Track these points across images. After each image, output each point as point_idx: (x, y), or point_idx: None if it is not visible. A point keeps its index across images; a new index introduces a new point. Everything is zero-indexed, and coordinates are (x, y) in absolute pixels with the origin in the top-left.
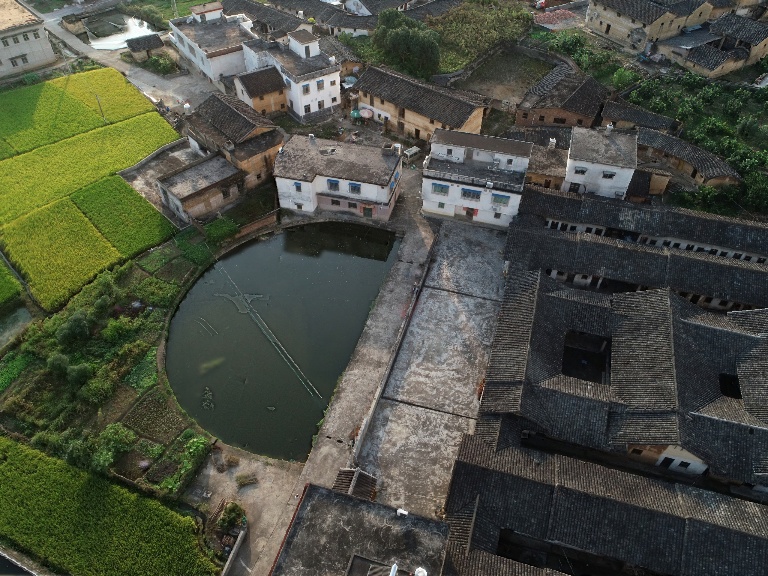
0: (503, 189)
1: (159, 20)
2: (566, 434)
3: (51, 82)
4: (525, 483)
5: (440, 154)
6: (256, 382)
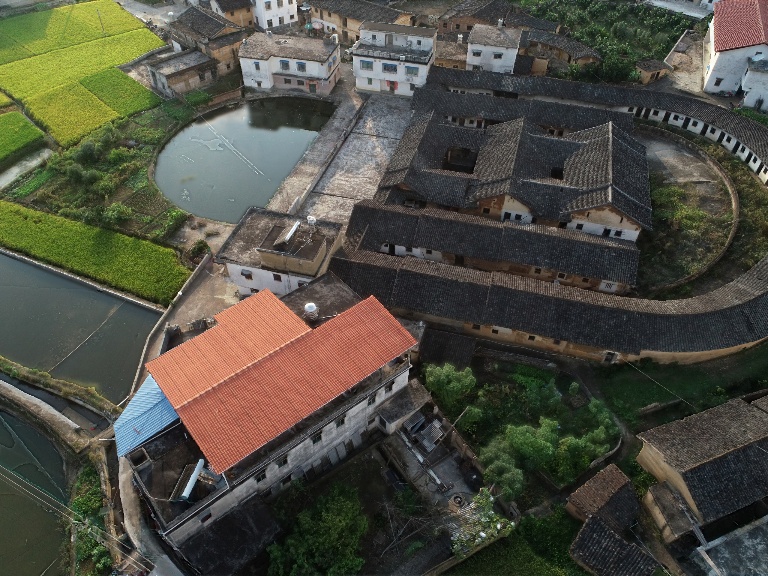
0: (413, 61)
1: None
2: (437, 199)
3: (59, 9)
4: (400, 216)
5: (367, 40)
6: (221, 188)
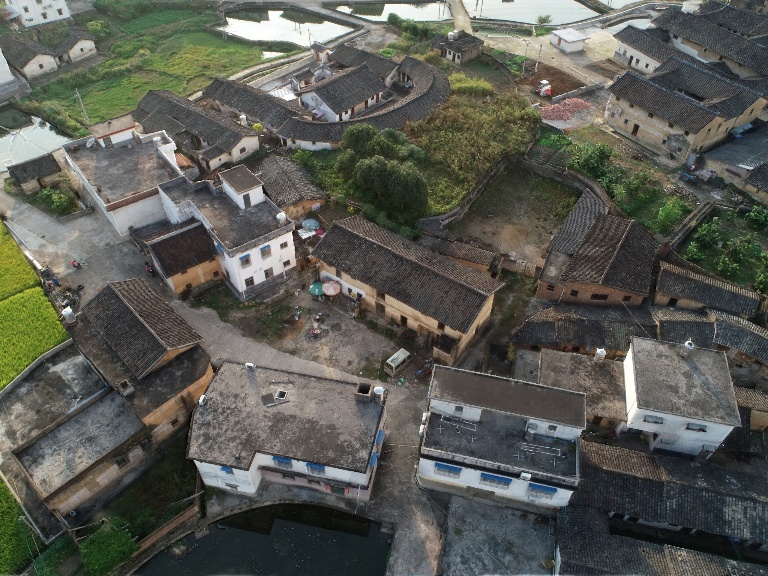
0: (546, 481)
1: (62, 123)
2: None
3: None
4: None
5: (444, 410)
6: None
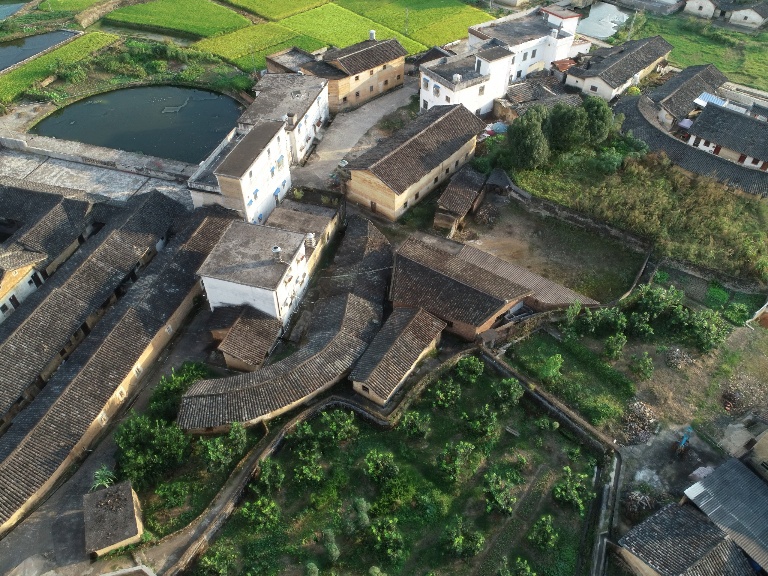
0: None
1: None
2: None
3: (468, 7)
4: None
5: None
6: (100, 118)
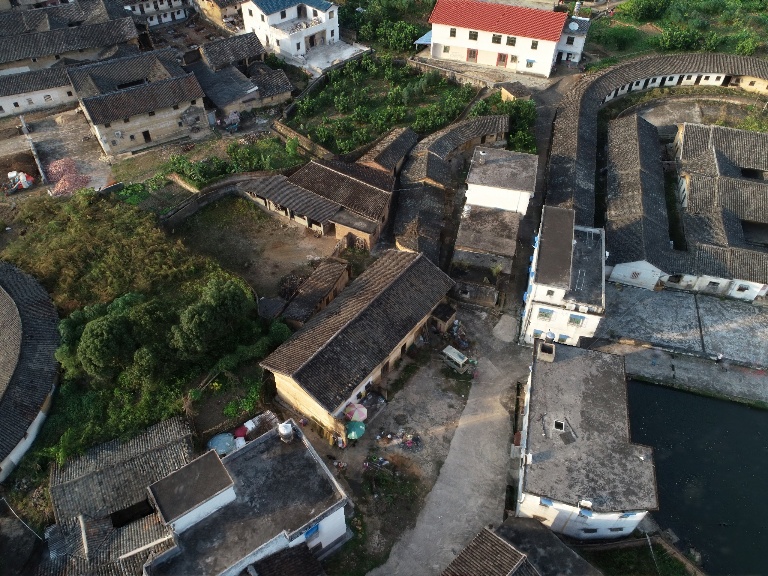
0: None
1: None
2: None
3: None
4: None
5: None
6: None
